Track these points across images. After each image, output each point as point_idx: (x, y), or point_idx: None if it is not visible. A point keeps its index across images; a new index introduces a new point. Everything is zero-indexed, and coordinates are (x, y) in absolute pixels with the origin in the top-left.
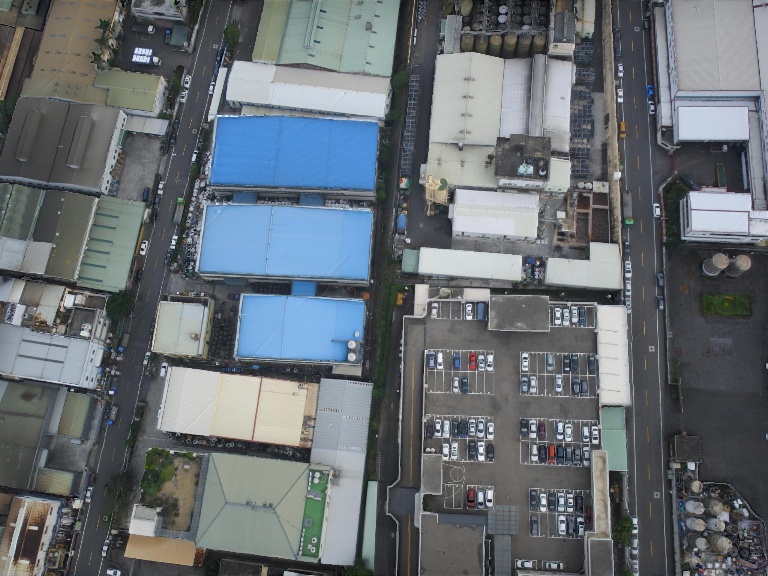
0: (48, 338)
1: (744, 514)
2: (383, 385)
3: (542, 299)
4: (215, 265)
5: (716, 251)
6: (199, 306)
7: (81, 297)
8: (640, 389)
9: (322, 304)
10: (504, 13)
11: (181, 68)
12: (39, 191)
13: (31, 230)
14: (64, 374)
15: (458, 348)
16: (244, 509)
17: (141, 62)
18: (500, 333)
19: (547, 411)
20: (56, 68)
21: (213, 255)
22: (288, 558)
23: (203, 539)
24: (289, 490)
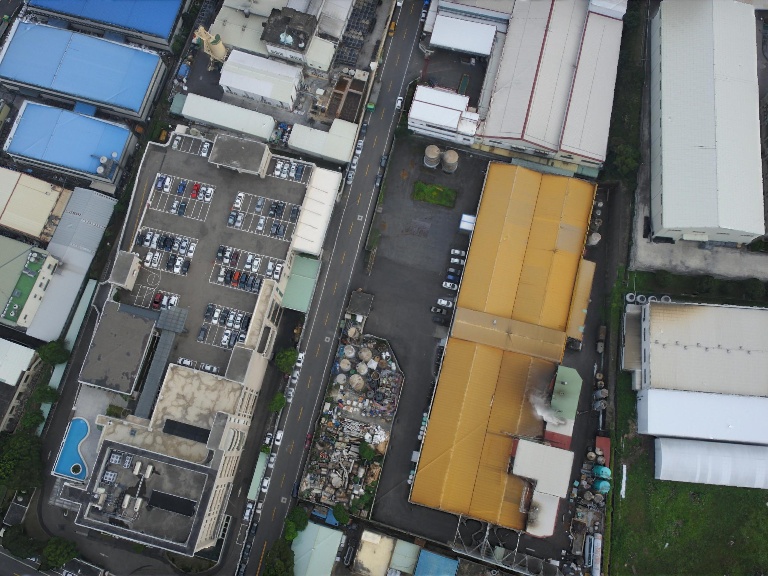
0: None
1: (392, 367)
2: (126, 203)
3: (260, 146)
4: (11, 72)
5: (441, 148)
6: None
7: None
8: (340, 249)
9: (92, 123)
10: None
11: None
12: None
13: None
14: None
15: (187, 178)
16: None
17: None
18: (226, 172)
19: (245, 244)
20: None
21: (12, 64)
22: None
23: None
24: (8, 262)
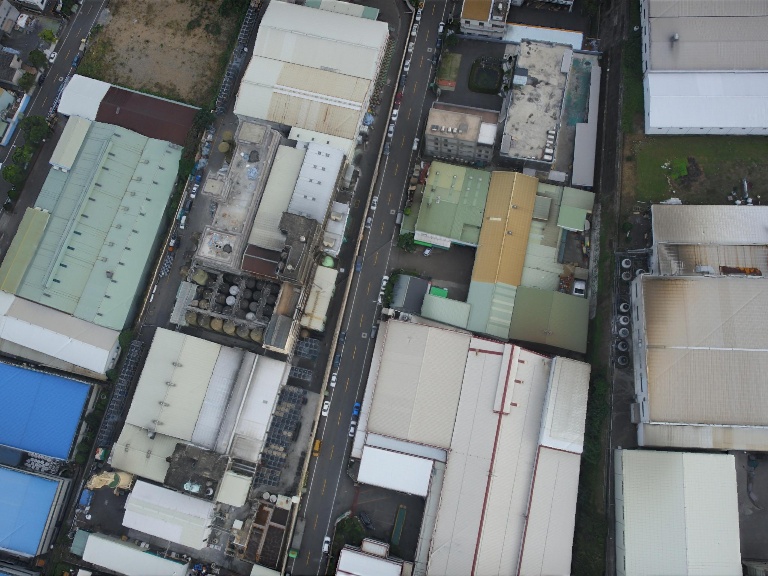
0: None
1: None
2: None
3: None
4: None
5: None
6: None
7: None
8: None
9: None
10: (234, 294)
11: None
12: None
13: None
14: None
15: None
16: None
17: None
18: None
19: None
20: None
21: None
22: None
23: None
24: None
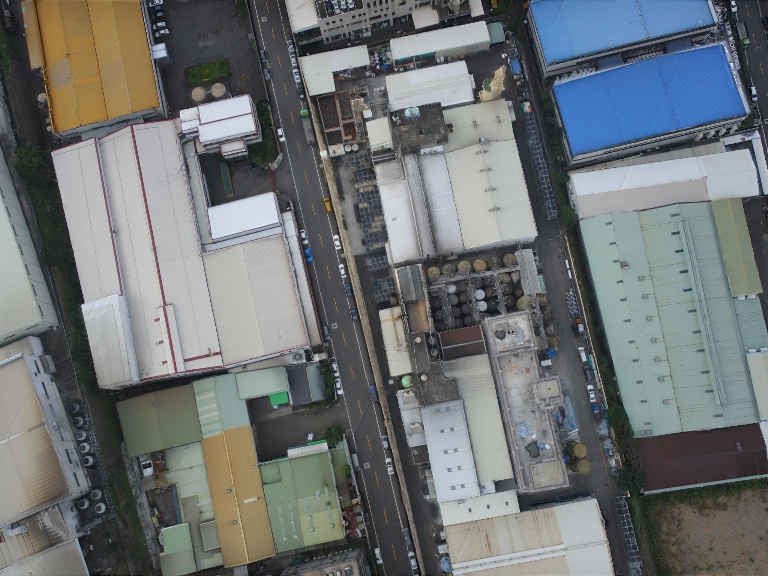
0: None
1: None
2: None
3: None
4: None
5: None
6: None
7: None
8: None
9: None
10: (480, 302)
11: None
12: None
13: None
14: None
15: None
16: None
17: None
18: None
19: None
20: None
21: None
22: None
23: None
24: None
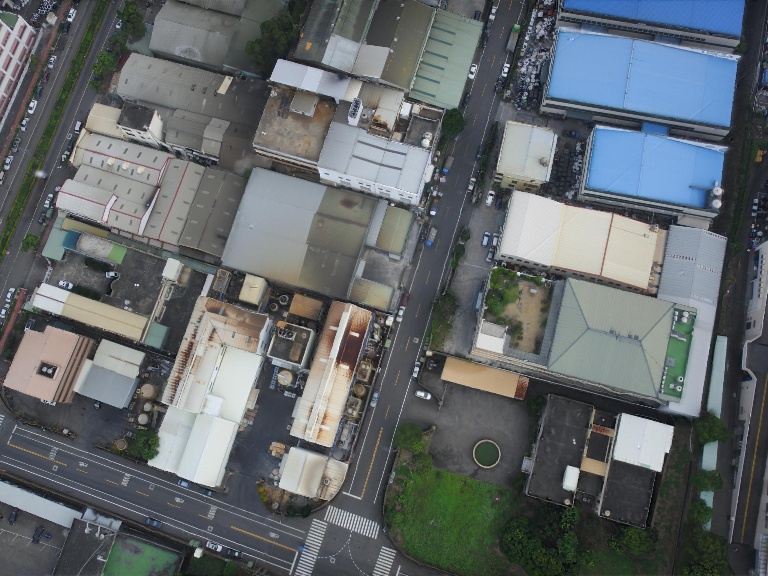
0: (384, 143)
1: None
2: (738, 241)
3: None
4: (566, 93)
5: None
6: (549, 132)
7: (419, 107)
8: None
9: (681, 148)
10: None
11: None
12: None
13: (364, 33)
14: (402, 181)
15: None
16: (607, 337)
17: None
18: None
19: None
20: None
21: (564, 83)
22: (648, 394)
23: (557, 363)
24: (654, 325)
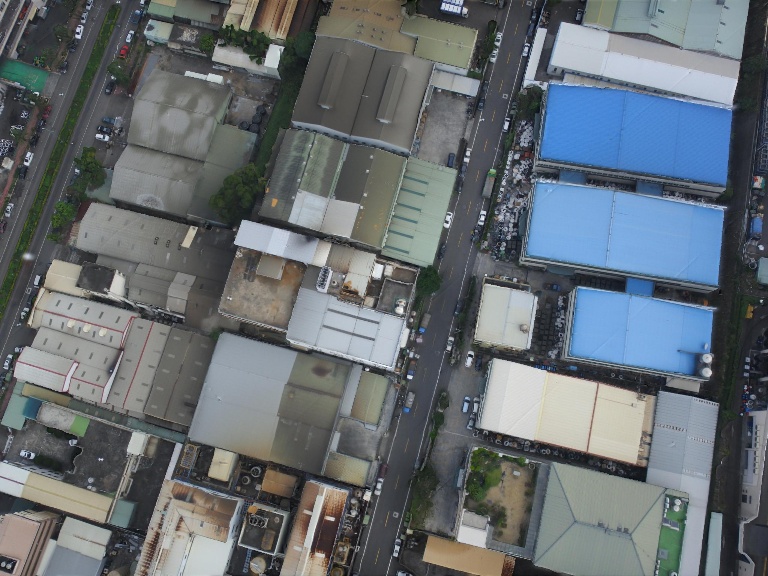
0: (356, 310)
1: None
2: (730, 407)
3: None
4: (545, 250)
5: None
6: (528, 294)
7: (391, 268)
8: None
9: (668, 308)
10: None
11: (494, 23)
12: (342, 144)
13: (332, 187)
14: (375, 353)
15: None
16: (595, 531)
17: (451, 12)
18: None
19: None
20: (359, 8)
21: (543, 239)
22: None
23: (544, 558)
24: (645, 515)
